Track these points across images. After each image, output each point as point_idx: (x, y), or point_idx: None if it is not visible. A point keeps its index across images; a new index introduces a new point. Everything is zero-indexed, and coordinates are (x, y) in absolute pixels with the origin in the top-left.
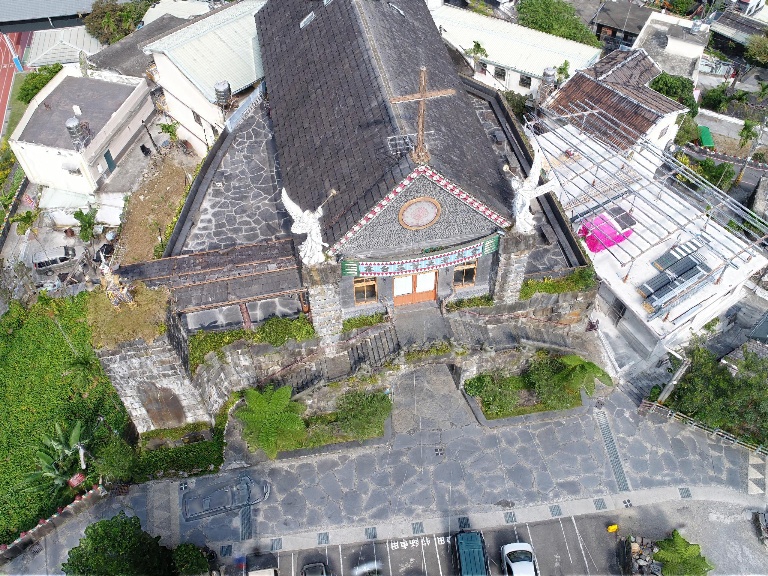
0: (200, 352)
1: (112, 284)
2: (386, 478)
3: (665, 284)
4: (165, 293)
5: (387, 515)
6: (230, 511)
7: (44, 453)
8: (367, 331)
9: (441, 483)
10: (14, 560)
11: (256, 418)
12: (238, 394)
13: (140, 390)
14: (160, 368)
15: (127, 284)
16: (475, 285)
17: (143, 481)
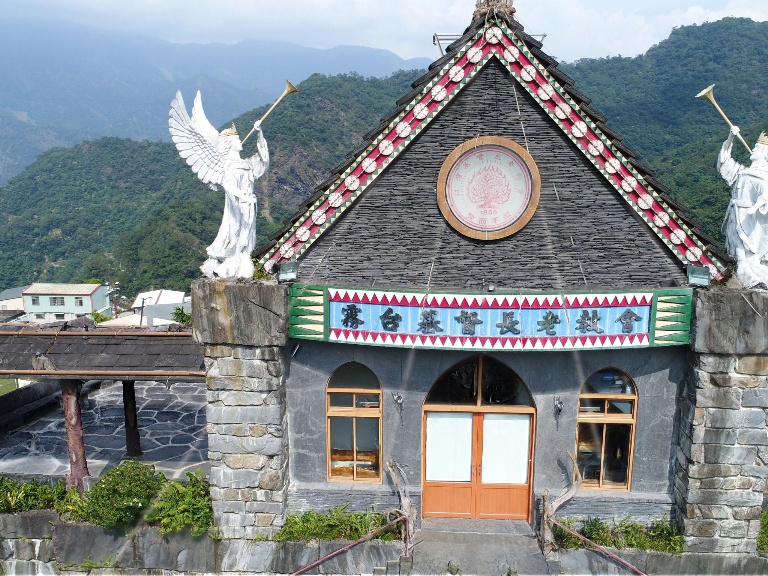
0: None
1: None
2: None
3: None
4: None
5: None
6: None
7: None
8: (343, 555)
9: None
10: None
11: None
12: None
13: None
14: None
15: None
16: (632, 488)
17: None
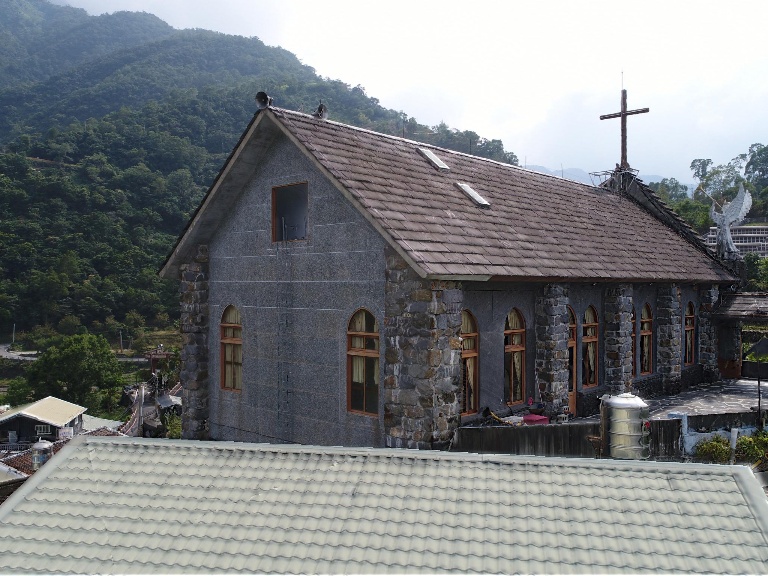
0: None
1: None
2: None
3: None
4: None
5: None
6: None
7: None
8: None
9: None
10: None
11: None
12: None
13: None
14: None
15: None
16: None
17: None
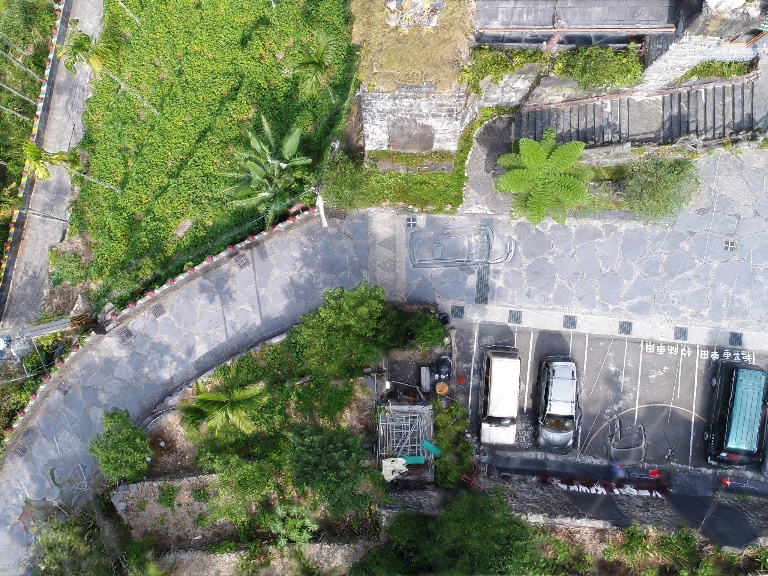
0: (476, 75)
1: (417, 7)
2: (656, 265)
3: None
4: (467, 3)
5: (648, 311)
6: (465, 266)
7: (255, 163)
8: (710, 82)
9: (722, 286)
10: (219, 269)
11: (527, 175)
12: (489, 111)
13: (395, 125)
14: (433, 109)
15: (438, 8)
16: None
17: (364, 206)
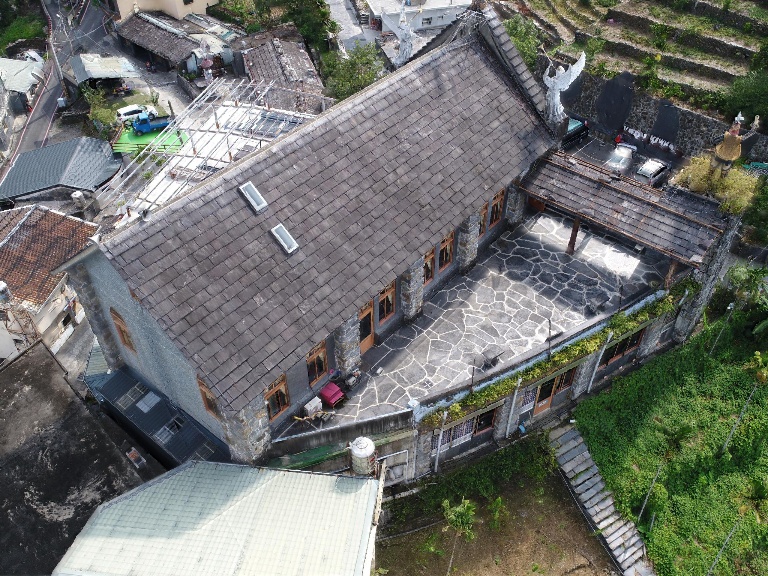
0: None
1: None
2: None
3: (294, 125)
4: None
5: None
6: None
7: None
8: None
9: None
10: None
11: None
12: None
13: None
14: None
15: None
16: None
17: None
